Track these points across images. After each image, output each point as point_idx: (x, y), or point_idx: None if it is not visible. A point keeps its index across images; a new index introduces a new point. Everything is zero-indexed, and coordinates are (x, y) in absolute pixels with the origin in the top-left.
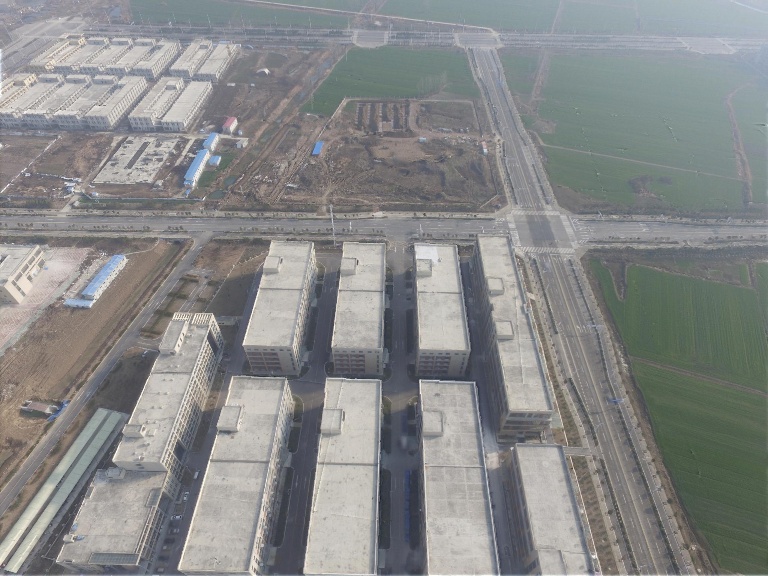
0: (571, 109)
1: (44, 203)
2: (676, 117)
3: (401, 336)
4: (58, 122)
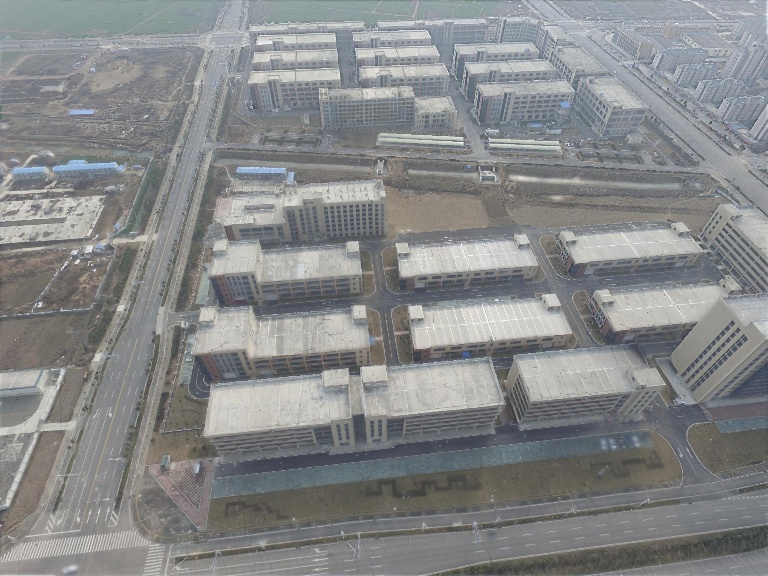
0: (71, 24)
1: (130, 252)
2: None
3: None
4: None
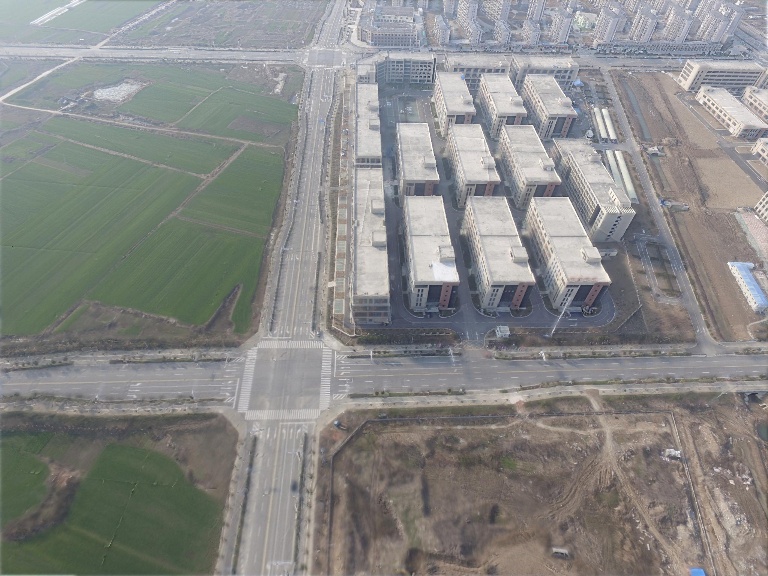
0: None
1: None
2: None
3: (454, 246)
4: None
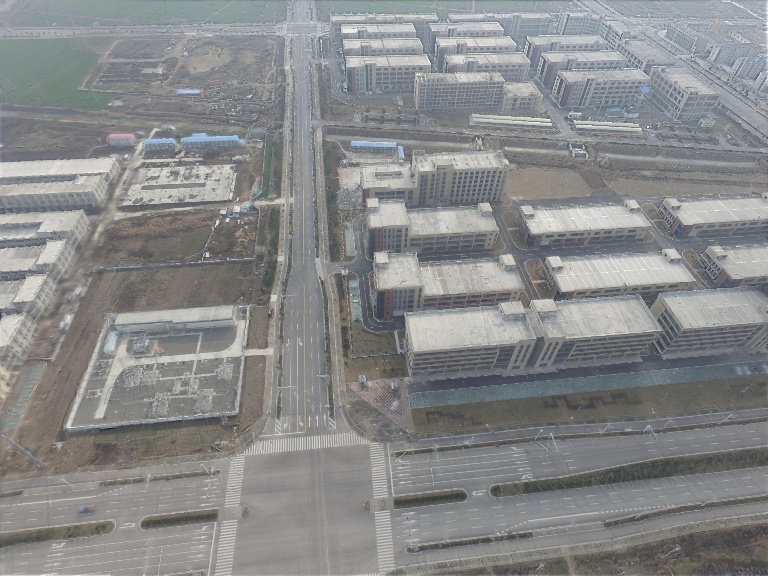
0: (149, 12)
1: None
2: None
3: None
4: (60, 271)
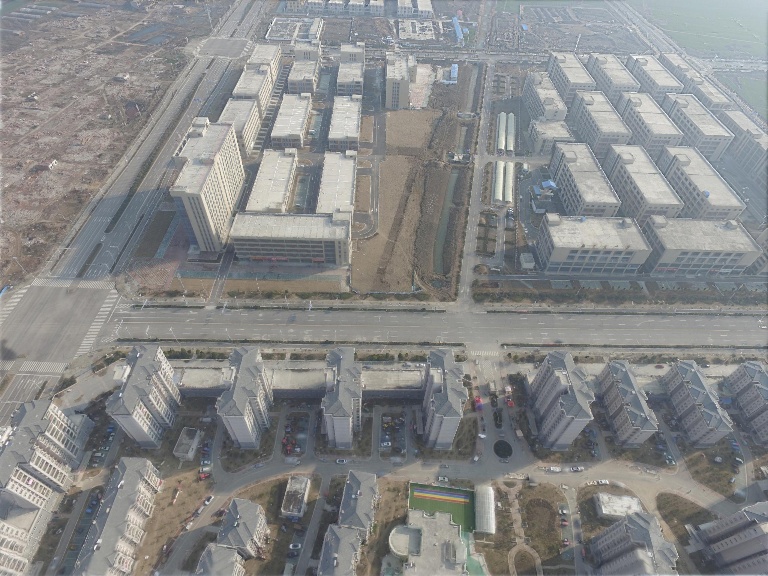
0: (673, 14)
1: (384, 45)
2: (743, 19)
3: None
4: (350, 10)
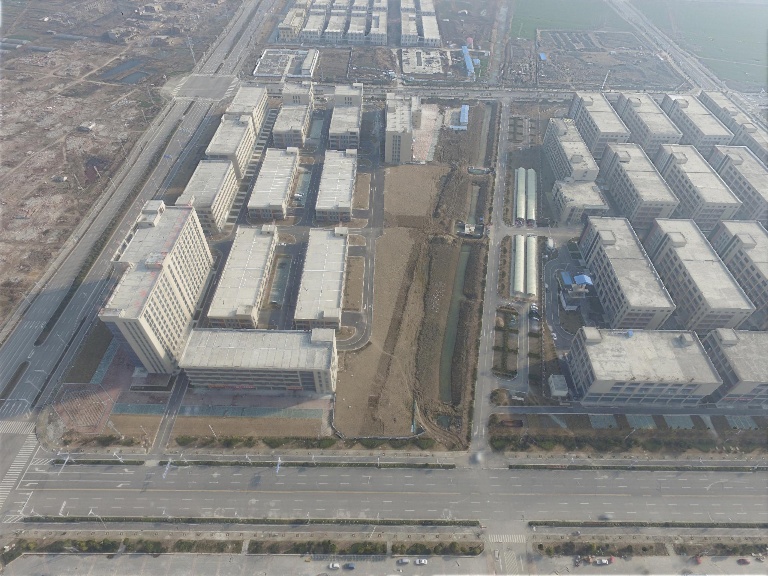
0: (706, 38)
1: (385, 81)
2: None
3: None
4: (348, 39)
